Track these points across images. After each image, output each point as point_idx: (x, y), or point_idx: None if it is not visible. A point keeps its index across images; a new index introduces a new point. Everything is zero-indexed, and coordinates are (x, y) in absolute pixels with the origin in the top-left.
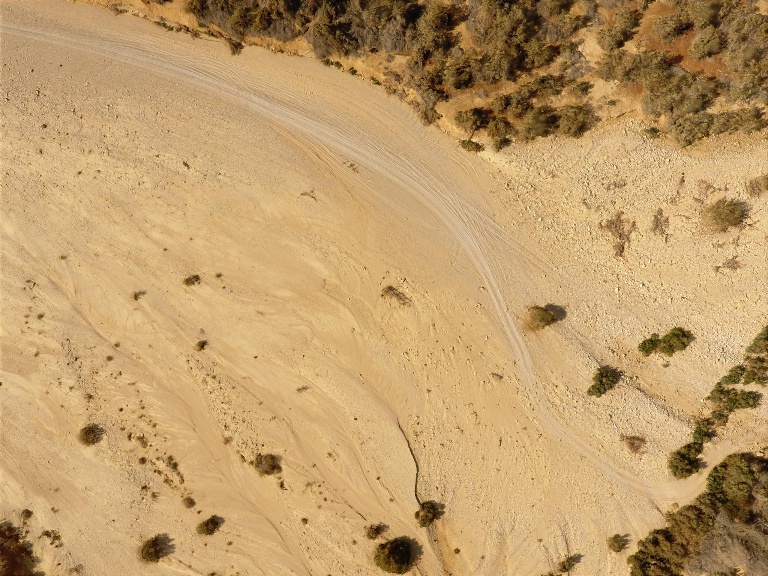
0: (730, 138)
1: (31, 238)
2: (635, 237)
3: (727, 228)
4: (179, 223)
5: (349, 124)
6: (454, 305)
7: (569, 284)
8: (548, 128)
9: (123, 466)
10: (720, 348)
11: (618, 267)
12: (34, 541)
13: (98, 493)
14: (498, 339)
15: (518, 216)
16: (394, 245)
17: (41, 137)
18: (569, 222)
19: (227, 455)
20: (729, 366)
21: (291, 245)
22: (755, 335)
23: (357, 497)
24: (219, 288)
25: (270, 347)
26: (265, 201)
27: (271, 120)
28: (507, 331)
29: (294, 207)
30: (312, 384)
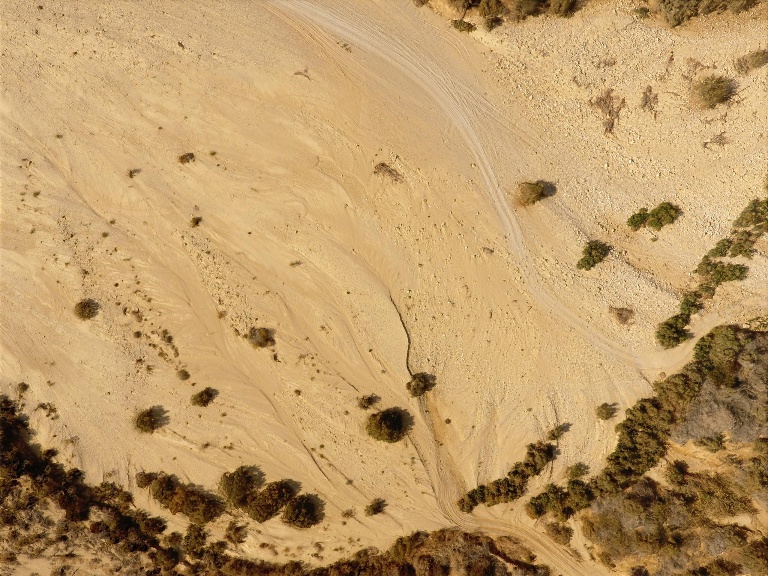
0: (719, 18)
1: (27, 117)
2: (624, 114)
3: (715, 105)
4: (174, 102)
5: (342, 5)
6: (446, 181)
7: (559, 161)
8: (539, 7)
9: (118, 340)
10: (707, 222)
11: (608, 144)
12: (30, 414)
13: (93, 366)
14: (489, 214)
15: (509, 94)
16: (387, 123)
17: (37, 18)
18: (559, 100)
19: (221, 329)
20: (716, 239)
21: (285, 123)
22: (742, 209)
23: (349, 369)
24: (213, 166)
25: (264, 223)
26: (259, 80)
27: (265, 1)
28: (498, 206)
29: (288, 86)
30: (305, 259)
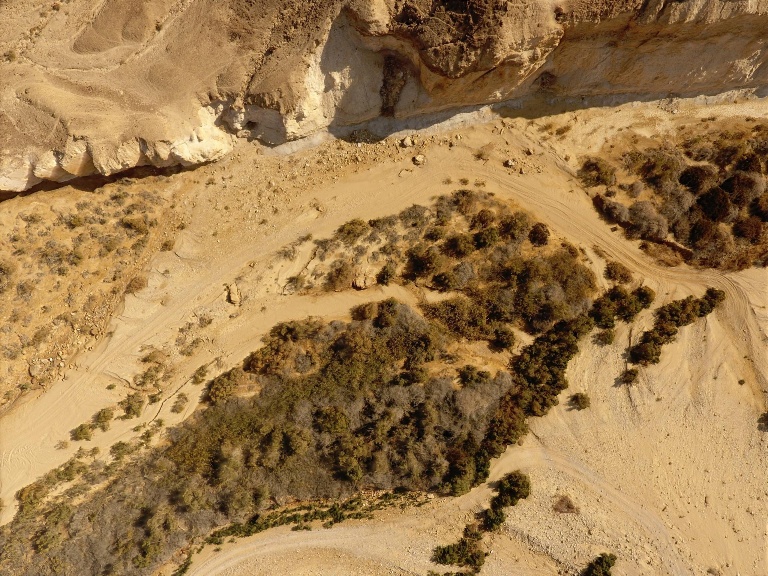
0: None
1: None
2: None
3: None
4: None
5: None
6: None
7: None
8: None
9: None
10: None
11: None
12: None
13: None
14: None
15: None
16: None
17: None
18: None
19: None
20: None
21: None
22: None
23: None
24: None
25: None
26: None
27: None
28: None
29: None
30: None
